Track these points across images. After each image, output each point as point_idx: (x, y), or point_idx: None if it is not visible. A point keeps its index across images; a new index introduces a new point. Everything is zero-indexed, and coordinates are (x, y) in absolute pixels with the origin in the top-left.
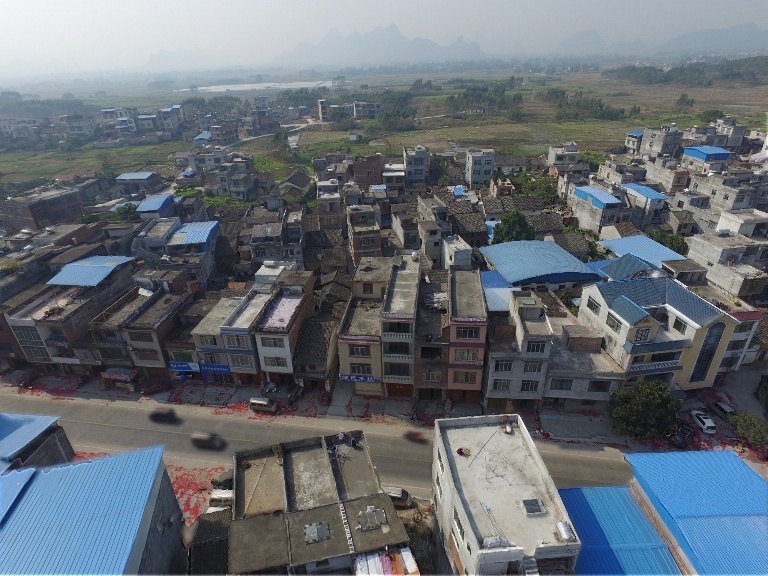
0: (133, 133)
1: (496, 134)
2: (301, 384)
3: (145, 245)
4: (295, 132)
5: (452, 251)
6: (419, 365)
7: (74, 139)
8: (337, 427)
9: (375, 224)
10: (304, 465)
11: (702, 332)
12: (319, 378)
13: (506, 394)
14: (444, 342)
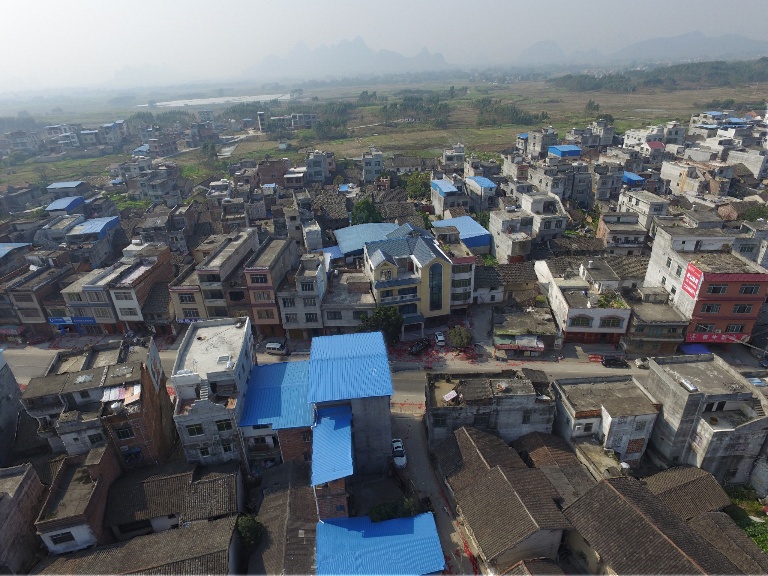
0: (75, 147)
1: (417, 140)
2: (154, 330)
3: (48, 236)
4: (234, 143)
5: (304, 232)
6: (230, 306)
7: (17, 154)
8: (173, 357)
9: (244, 213)
10: (104, 357)
11: (426, 271)
12: (164, 323)
13: (296, 325)
14: (243, 287)
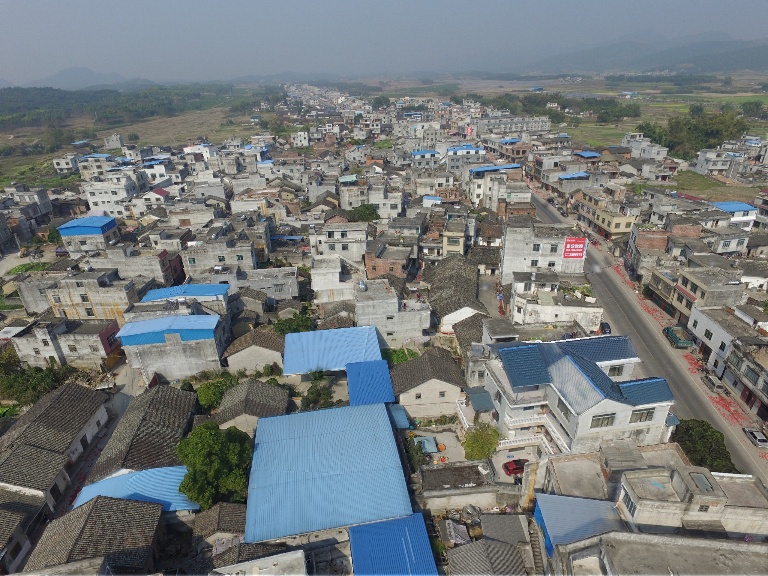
0: None
1: None
2: None
3: None
4: None
5: None
6: None
7: None
8: None
9: None
10: None
11: None
12: None
13: None
14: None
